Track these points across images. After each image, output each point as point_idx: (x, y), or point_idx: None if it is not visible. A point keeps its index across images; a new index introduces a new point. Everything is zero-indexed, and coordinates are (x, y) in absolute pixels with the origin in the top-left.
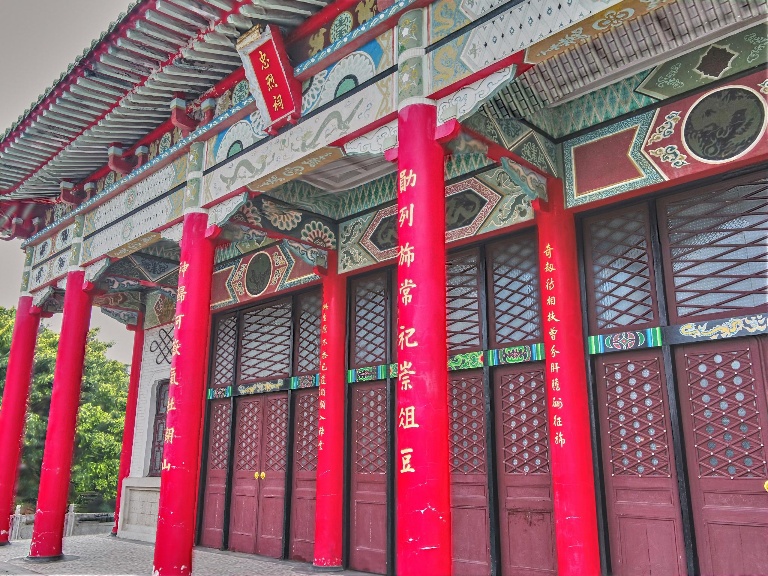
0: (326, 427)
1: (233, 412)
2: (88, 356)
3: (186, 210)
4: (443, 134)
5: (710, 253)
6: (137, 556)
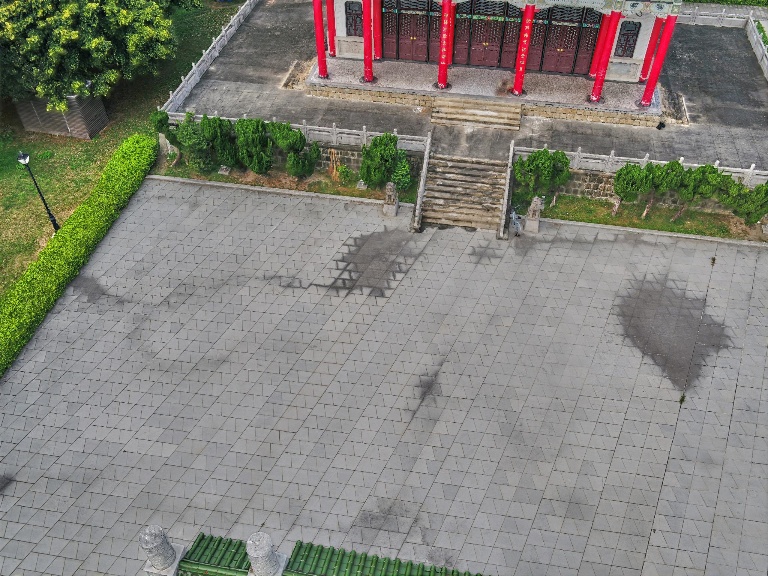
0: (451, 31)
1: (398, 18)
2: None
3: None
4: (536, 11)
5: (562, 7)
6: None
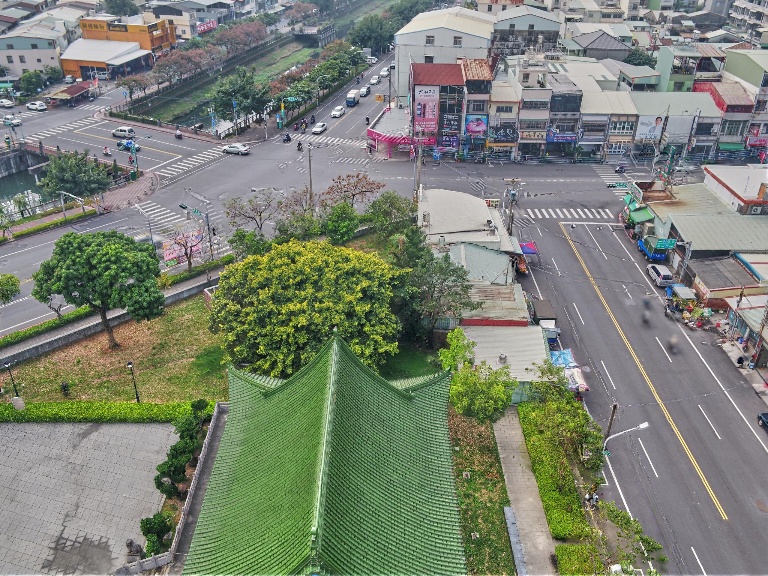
0: None
1: None
2: (360, 311)
3: None
4: None
5: None
6: None
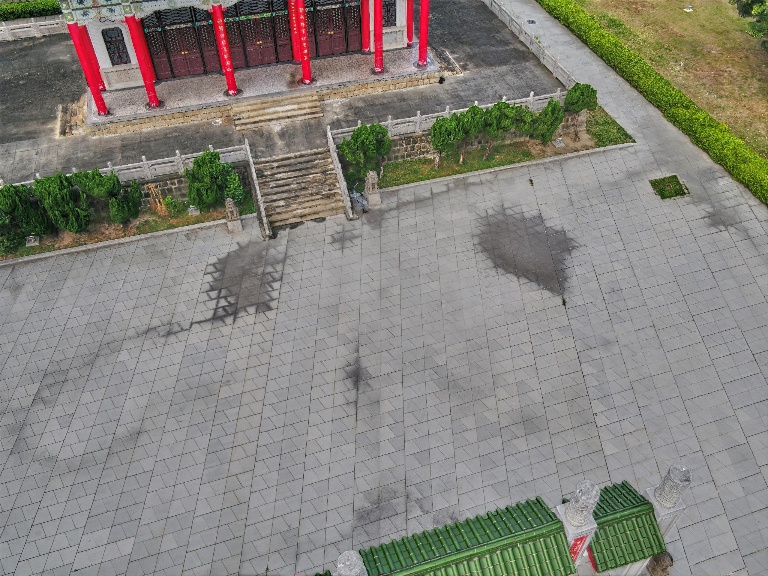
0: None
1: None
2: None
3: (216, 4)
4: None
5: None
6: None
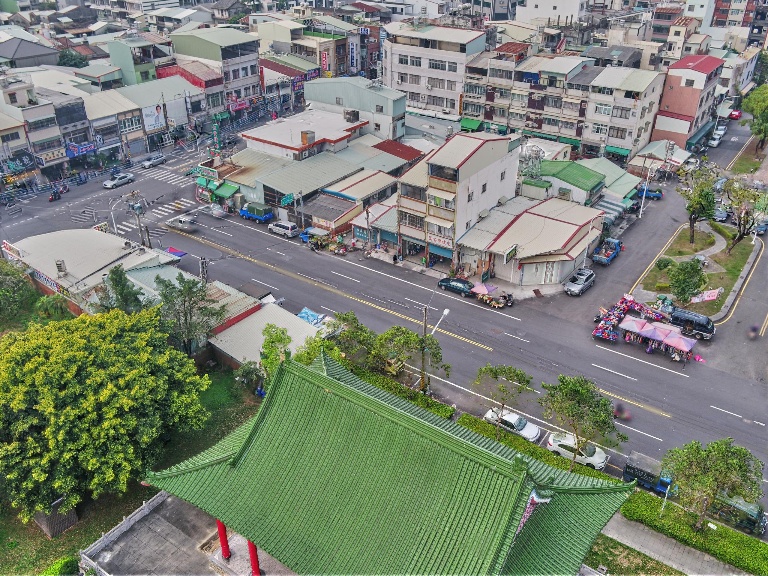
0: None
1: None
2: (163, 363)
3: None
4: None
5: None
6: (280, 569)
